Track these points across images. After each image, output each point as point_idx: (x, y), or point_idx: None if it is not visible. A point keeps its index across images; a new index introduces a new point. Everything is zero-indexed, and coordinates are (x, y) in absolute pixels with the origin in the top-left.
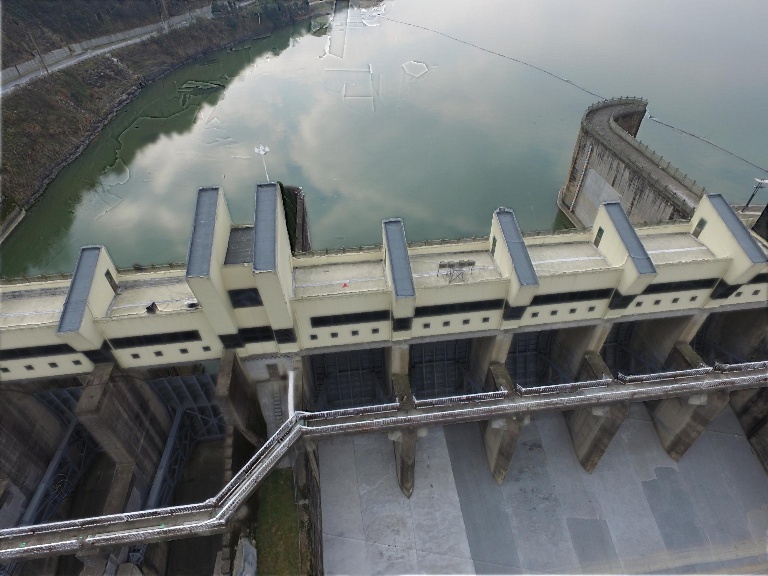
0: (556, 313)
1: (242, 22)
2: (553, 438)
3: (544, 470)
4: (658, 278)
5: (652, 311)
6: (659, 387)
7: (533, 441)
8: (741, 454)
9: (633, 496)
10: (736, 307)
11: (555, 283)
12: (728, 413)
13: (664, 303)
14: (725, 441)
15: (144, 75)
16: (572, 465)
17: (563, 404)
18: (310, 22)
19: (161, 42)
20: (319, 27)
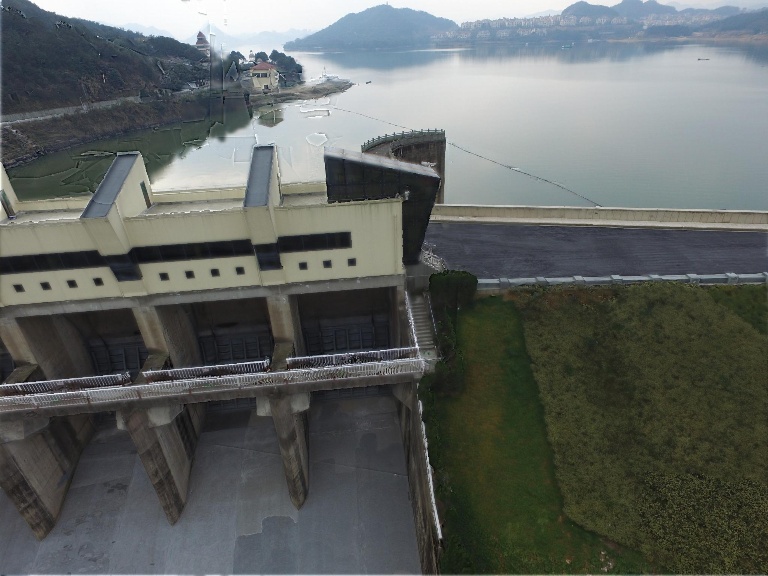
0: (50, 287)
1: (172, 107)
2: (148, 476)
3: (112, 519)
4: (162, 237)
5: (194, 288)
6: (170, 383)
7: (119, 480)
8: (392, 499)
9: (216, 557)
10: (320, 287)
11: (11, 239)
12: (395, 445)
13: (202, 276)
14: (377, 482)
15: (45, 146)
16: (154, 513)
17: (37, 406)
18: (251, 111)
19: (75, 119)
20: (260, 115)
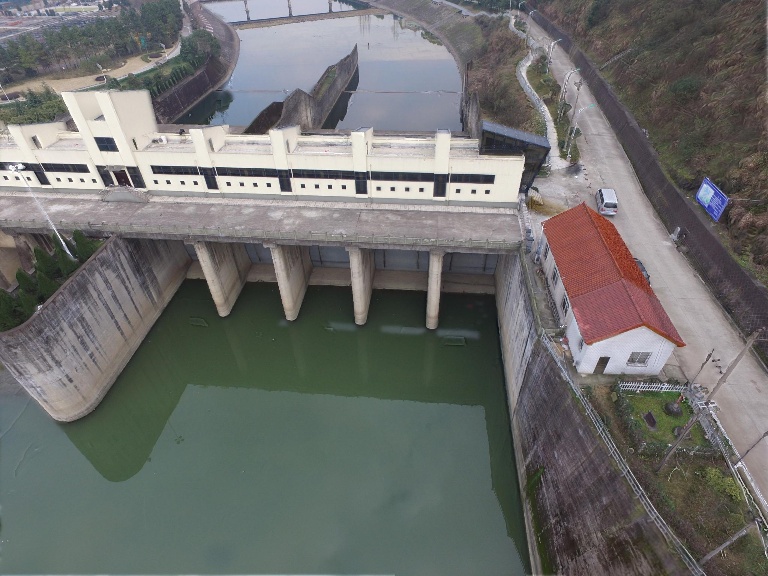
0: None
1: None
2: None
3: None
4: None
5: None
6: None
7: None
8: None
9: None
10: None
11: None
12: None
13: None
14: None
15: None
16: None
17: None
18: None
19: None
20: None
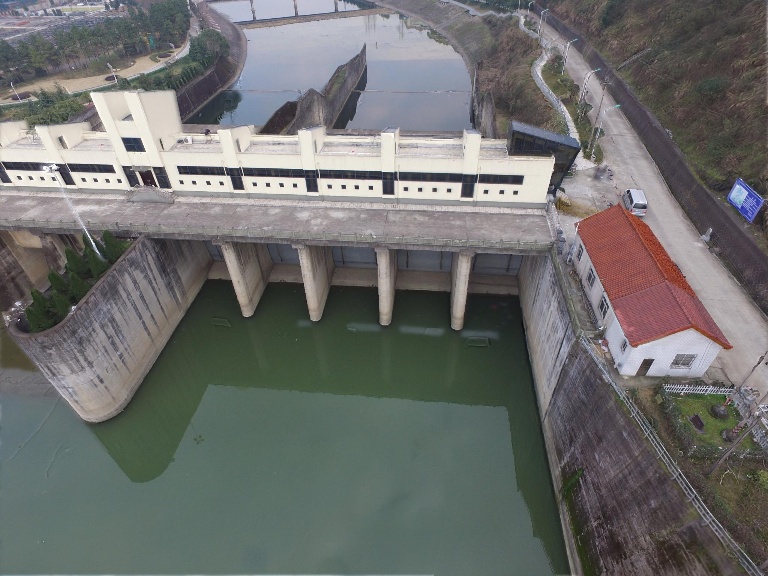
0: None
1: None
2: None
3: None
4: None
5: None
6: None
7: None
8: None
9: None
10: None
11: None
12: None
13: None
14: None
15: None
16: None
17: None
18: None
19: None
20: None
